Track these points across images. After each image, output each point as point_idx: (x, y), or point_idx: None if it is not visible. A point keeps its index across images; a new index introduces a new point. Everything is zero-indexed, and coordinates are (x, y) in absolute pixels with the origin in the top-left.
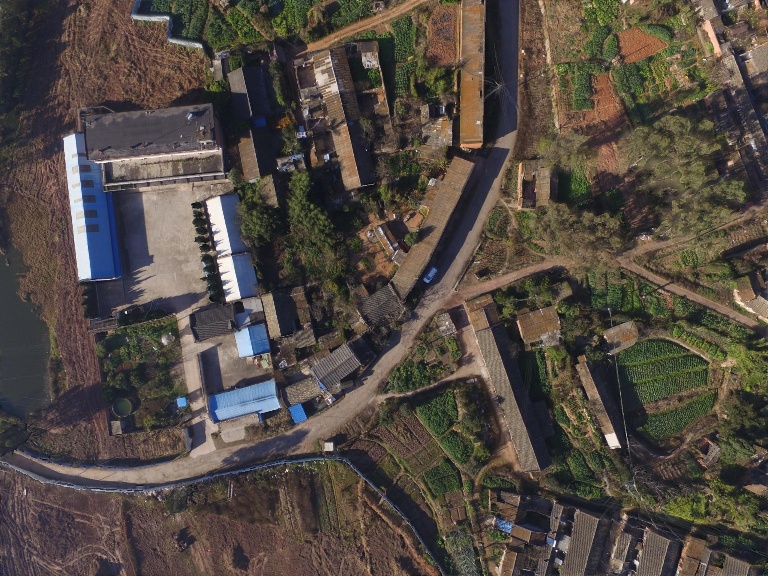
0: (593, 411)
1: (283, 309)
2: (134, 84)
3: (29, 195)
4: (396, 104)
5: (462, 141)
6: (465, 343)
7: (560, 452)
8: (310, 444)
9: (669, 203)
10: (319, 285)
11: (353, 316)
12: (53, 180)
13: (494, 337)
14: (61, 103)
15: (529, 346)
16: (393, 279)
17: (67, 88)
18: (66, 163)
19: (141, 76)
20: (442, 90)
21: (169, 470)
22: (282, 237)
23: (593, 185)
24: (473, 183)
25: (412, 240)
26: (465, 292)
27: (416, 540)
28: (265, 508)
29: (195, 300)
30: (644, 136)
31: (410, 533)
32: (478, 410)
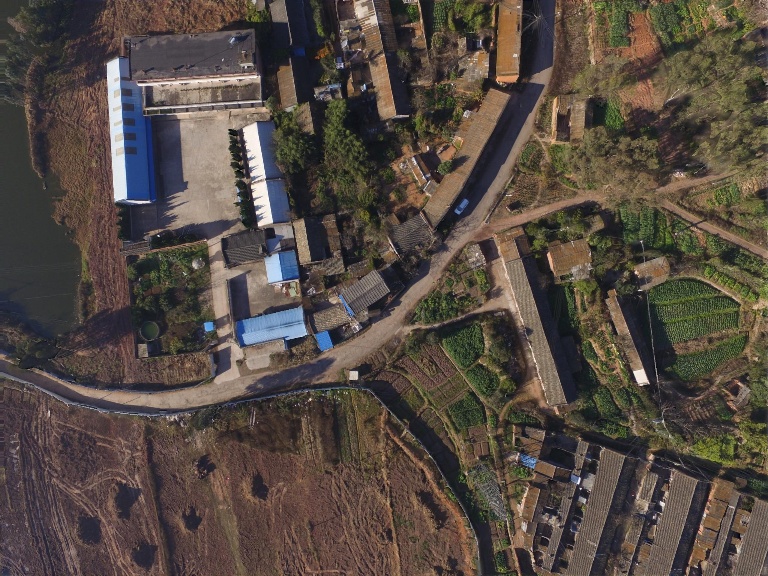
0: (622, 346)
1: (314, 235)
2: (177, 16)
3: (69, 121)
4: (434, 38)
5: (498, 74)
6: (494, 276)
7: (587, 389)
8: (335, 373)
9: (704, 140)
10: (350, 214)
11: (383, 245)
12: (93, 107)
13: (524, 267)
14: (105, 33)
15: (559, 279)
16: (425, 207)
17: (112, 18)
18: (108, 87)
19: (184, 8)
20: (480, 25)
21: (193, 396)
22: (315, 167)
23: (627, 121)
24: (507, 117)
25: (446, 167)
26: (496, 225)
27: (438, 474)
28: (287, 436)
29: (226, 227)
30: (684, 59)
31: (432, 467)
32: (505, 343)
